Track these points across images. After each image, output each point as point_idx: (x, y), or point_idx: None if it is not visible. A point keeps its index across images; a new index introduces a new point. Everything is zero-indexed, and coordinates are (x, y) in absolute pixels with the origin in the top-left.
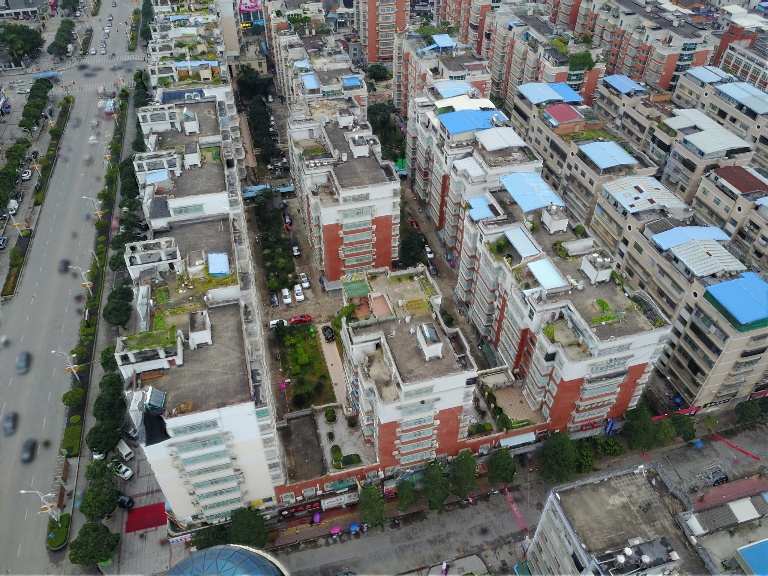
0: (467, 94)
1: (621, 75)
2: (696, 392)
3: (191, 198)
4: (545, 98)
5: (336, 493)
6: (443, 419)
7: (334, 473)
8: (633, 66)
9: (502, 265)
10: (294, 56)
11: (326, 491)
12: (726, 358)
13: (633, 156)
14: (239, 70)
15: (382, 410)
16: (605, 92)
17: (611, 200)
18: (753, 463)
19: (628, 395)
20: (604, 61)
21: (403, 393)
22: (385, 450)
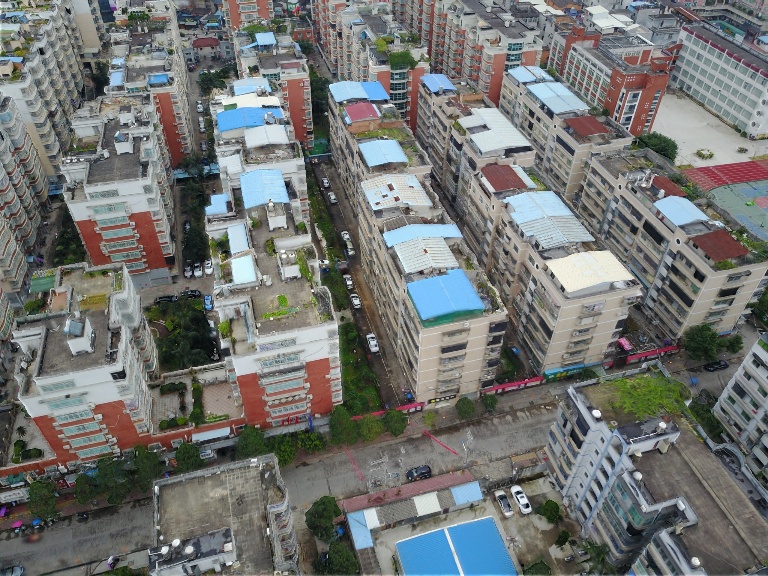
0: (256, 92)
1: None
2: (415, 388)
3: None
4: (349, 96)
5: (11, 487)
6: (107, 413)
7: (6, 467)
8: (472, 66)
9: None
10: (120, 53)
11: (4, 485)
12: (426, 354)
13: (417, 154)
14: (96, 67)
15: (24, 404)
16: (422, 91)
17: (366, 198)
18: None
19: (326, 390)
20: (427, 60)
21: (39, 387)
22: (54, 444)
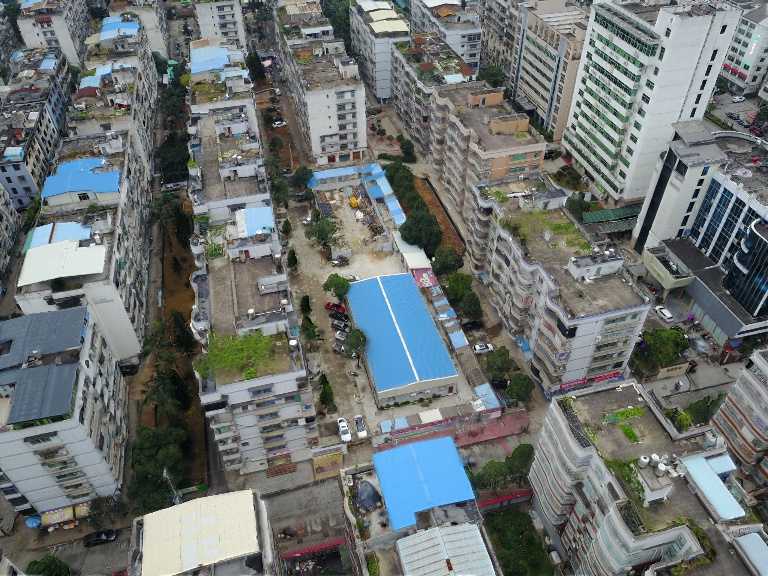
0: None
1: None
2: None
3: None
4: None
5: None
6: None
7: None
8: None
9: None
10: None
11: None
12: None
13: None
14: None
15: None
16: None
17: None
18: None
19: None
20: None
21: None
22: None
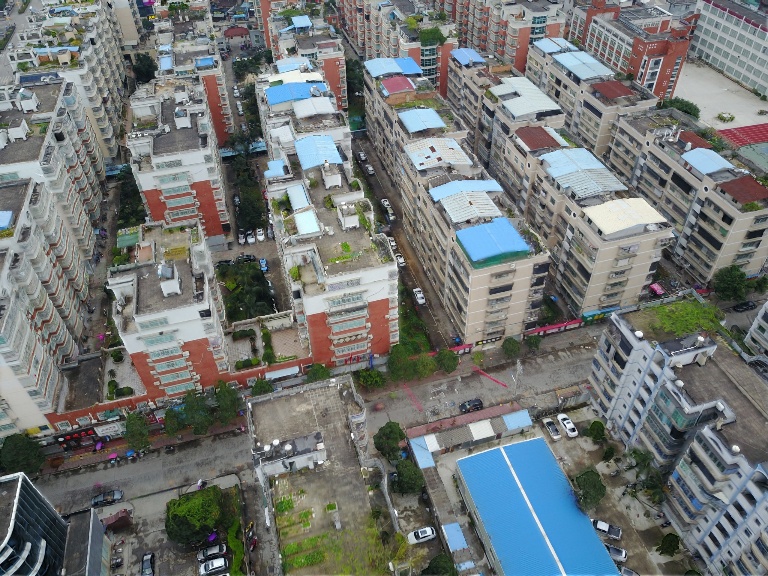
0: (299, 69)
1: (468, 49)
2: (464, 330)
3: (4, 166)
4: (384, 71)
5: (108, 421)
6: (193, 351)
7: (103, 403)
8: (497, 41)
9: (281, 218)
10: (164, 41)
11: (101, 420)
12: (475, 295)
13: (452, 122)
14: (136, 58)
15: (124, 340)
16: (452, 65)
17: (409, 160)
18: (512, 392)
19: (385, 331)
20: (455, 36)
21: (138, 324)
22: (146, 381)
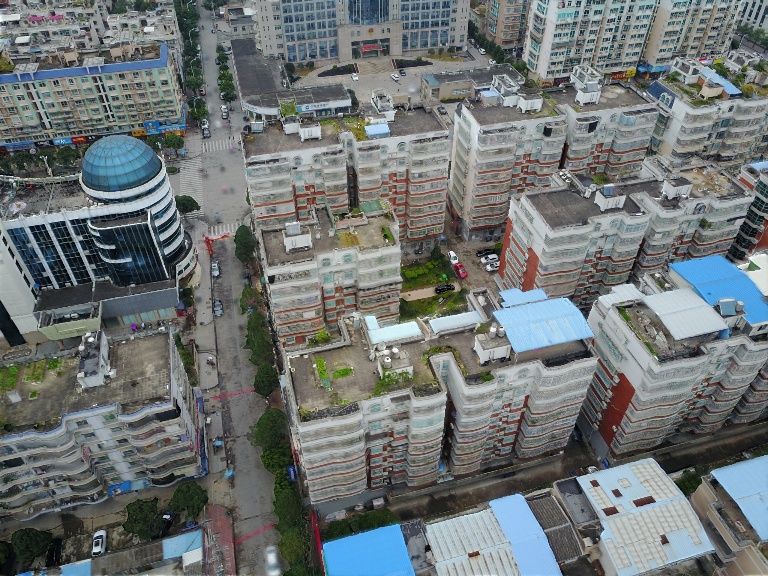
0: None
1: None
2: None
3: None
4: None
5: None
6: None
7: None
8: None
9: None
10: None
11: None
12: None
13: None
14: None
15: None
16: None
17: None
18: None
19: None
20: None
21: None
22: None
